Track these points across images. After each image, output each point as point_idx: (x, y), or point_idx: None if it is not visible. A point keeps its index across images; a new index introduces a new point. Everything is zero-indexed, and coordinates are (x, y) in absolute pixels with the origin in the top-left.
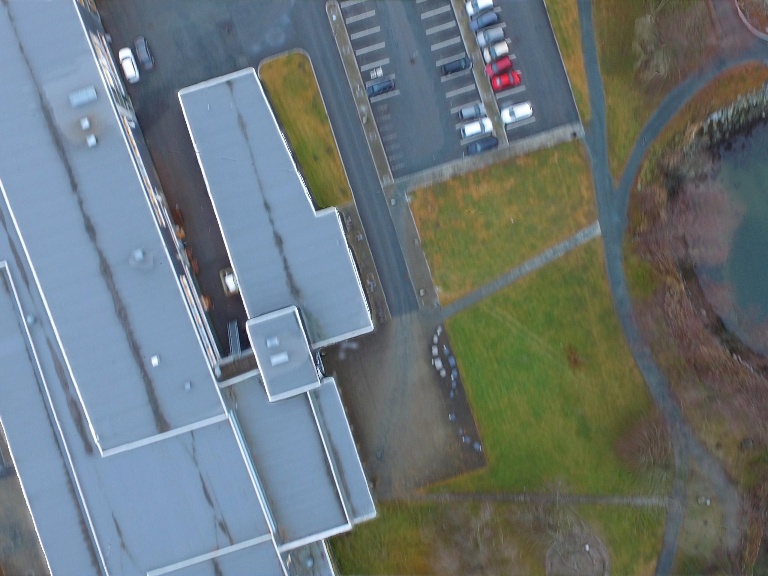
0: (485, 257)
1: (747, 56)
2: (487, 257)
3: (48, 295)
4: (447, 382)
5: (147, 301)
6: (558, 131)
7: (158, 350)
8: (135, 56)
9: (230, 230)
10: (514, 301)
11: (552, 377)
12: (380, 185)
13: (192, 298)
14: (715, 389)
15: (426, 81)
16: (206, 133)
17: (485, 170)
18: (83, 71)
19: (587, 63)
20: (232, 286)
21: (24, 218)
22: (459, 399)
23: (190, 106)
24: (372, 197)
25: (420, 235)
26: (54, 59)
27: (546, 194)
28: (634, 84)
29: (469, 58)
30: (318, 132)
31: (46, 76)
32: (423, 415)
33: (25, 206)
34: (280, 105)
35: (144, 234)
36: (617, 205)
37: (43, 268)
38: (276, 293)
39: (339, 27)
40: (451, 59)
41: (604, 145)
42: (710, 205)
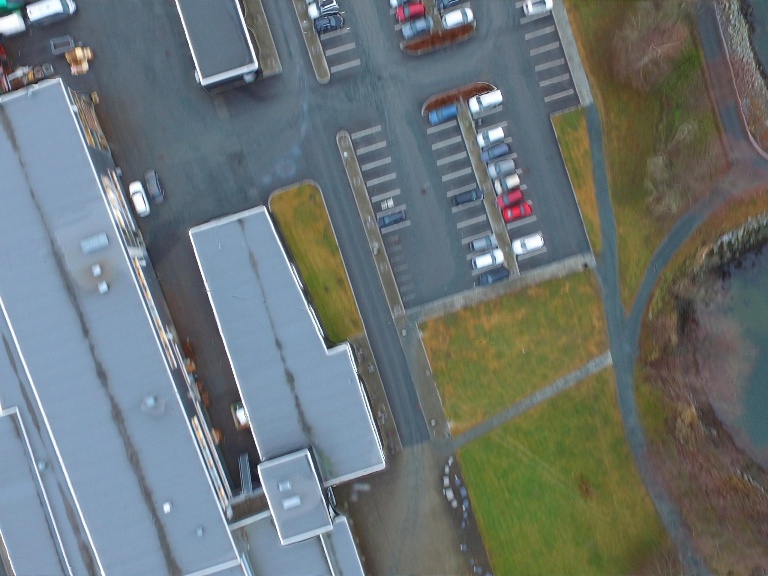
0: (496, 387)
1: (757, 179)
2: (498, 387)
3: (59, 441)
4: (458, 512)
5: (159, 446)
6: (569, 261)
7: (170, 496)
8: (145, 190)
9: (241, 368)
10: (525, 431)
11: (564, 506)
12: (391, 316)
13: (203, 438)
14: (726, 515)
15: (437, 212)
16: (217, 271)
17: (496, 300)
18: (94, 217)
19: (598, 193)
20: (243, 419)
21: (35, 364)
22: (470, 529)
23: (201, 245)
24: (383, 328)
25: (431, 365)
26: (65, 205)
27: (557, 324)
28: (645, 213)
29: (480, 190)
30: (329, 263)
31: (57, 222)
32: (434, 545)
33: (36, 352)
34: (291, 237)
35: (156, 380)
36: (628, 335)
37: (54, 414)
38: (288, 431)
39: (350, 158)
40: (462, 190)
41: (615, 275)
42: (720, 323)
